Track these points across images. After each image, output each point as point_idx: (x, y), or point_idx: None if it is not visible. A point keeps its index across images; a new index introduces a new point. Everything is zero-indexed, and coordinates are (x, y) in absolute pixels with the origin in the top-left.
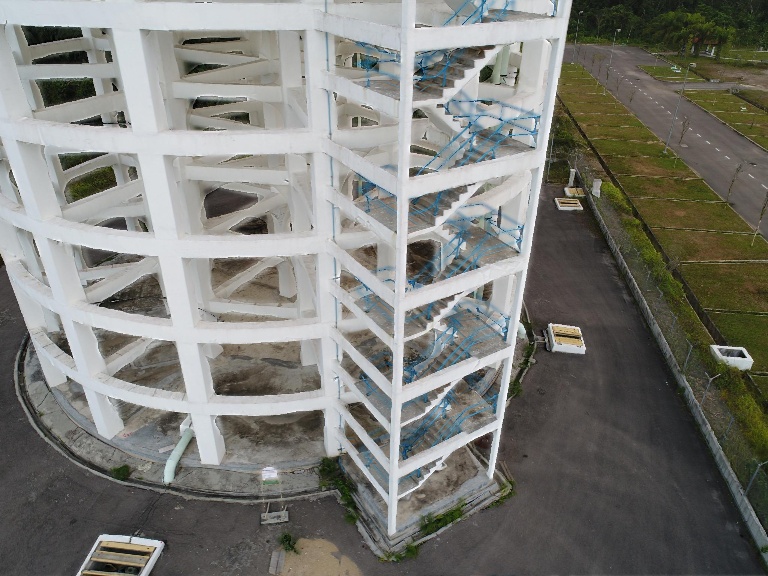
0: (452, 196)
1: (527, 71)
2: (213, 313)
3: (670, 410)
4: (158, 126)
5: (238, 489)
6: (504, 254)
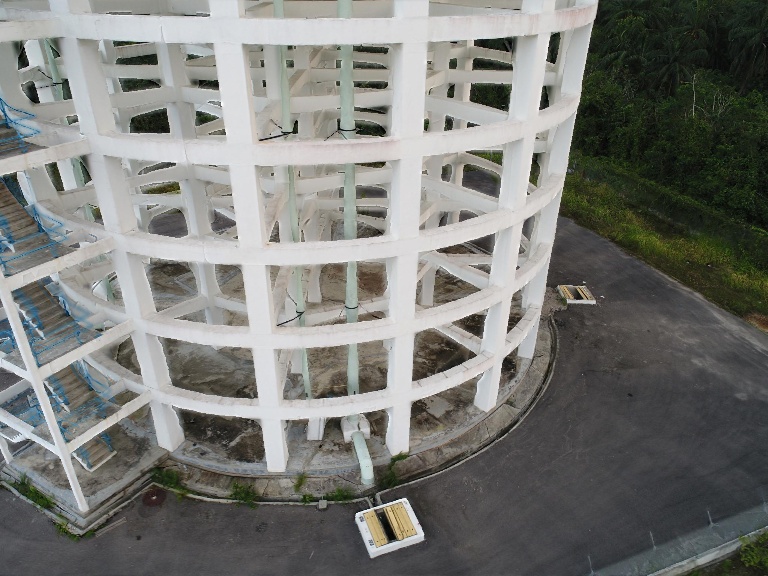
0: None
1: None
2: (197, 265)
3: None
4: None
5: None
6: None
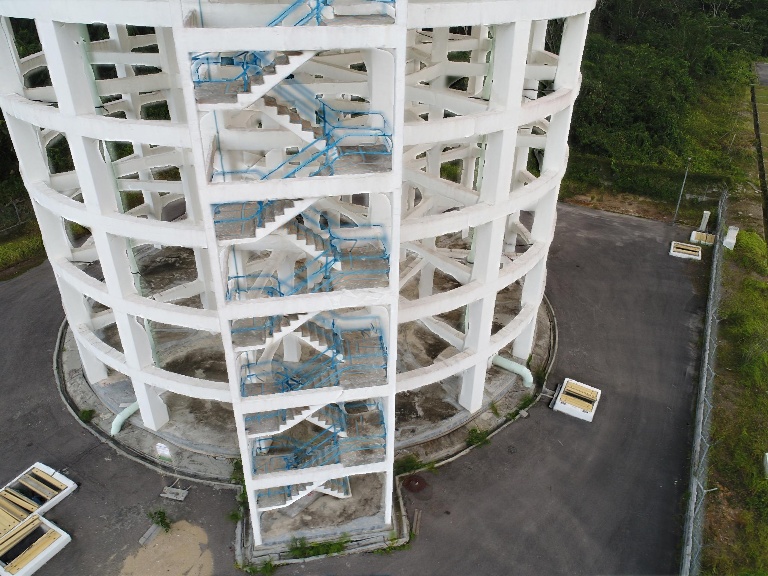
0: (282, 209)
1: (498, 87)
2: None
3: (658, 514)
4: (76, 109)
5: None
6: (374, 282)
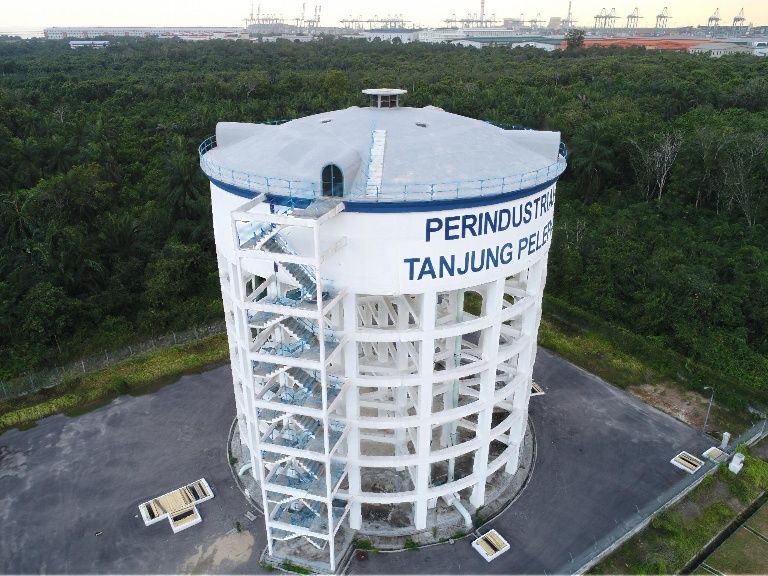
0: None
1: None
2: None
3: None
4: (241, 336)
5: (254, 496)
6: (322, 450)
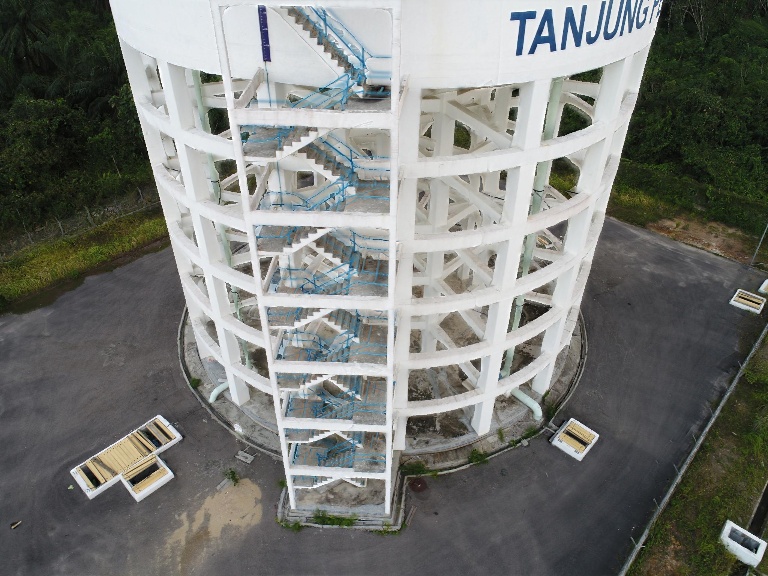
0: (313, 310)
1: (507, 207)
2: None
3: (606, 552)
4: (197, 198)
5: (241, 427)
6: (378, 359)
